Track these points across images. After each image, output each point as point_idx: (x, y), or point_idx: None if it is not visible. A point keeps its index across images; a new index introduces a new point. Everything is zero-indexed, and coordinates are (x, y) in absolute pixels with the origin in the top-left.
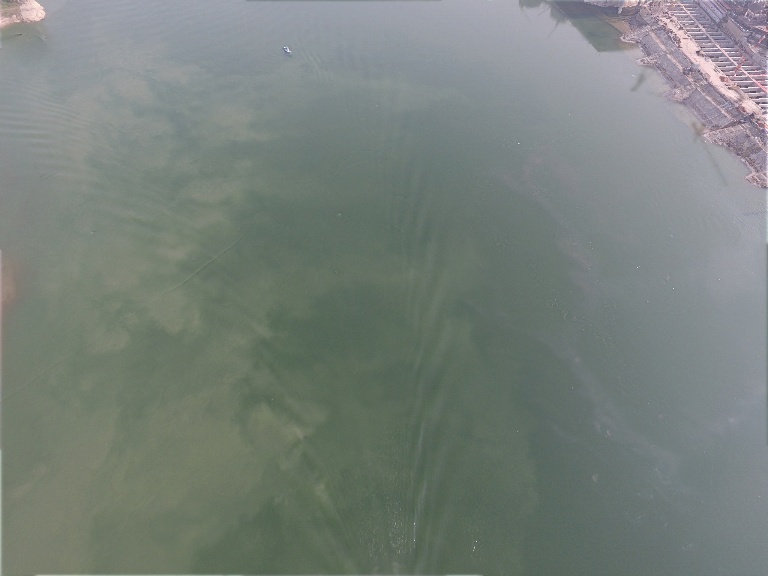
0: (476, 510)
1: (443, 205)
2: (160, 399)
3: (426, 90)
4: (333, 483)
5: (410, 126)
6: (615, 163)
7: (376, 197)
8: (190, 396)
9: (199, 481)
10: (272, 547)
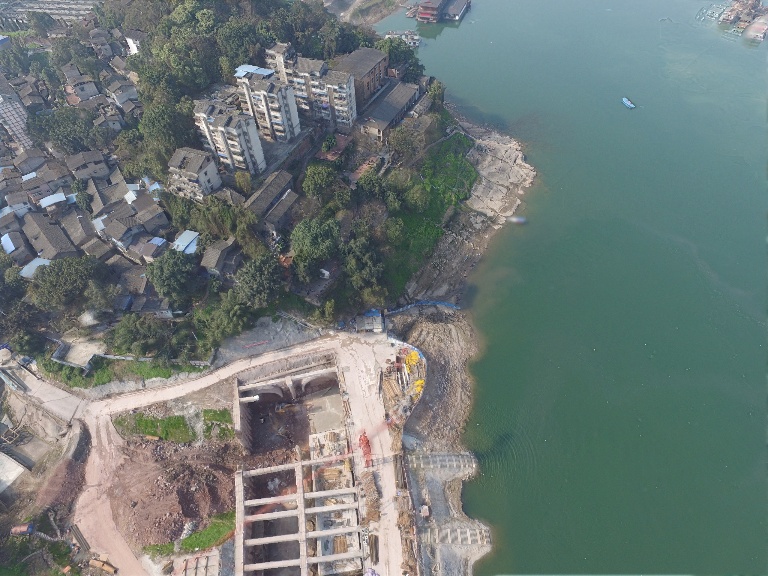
0: None
1: None
2: None
3: None
4: None
5: None
6: None
7: None
8: None
9: None
10: None
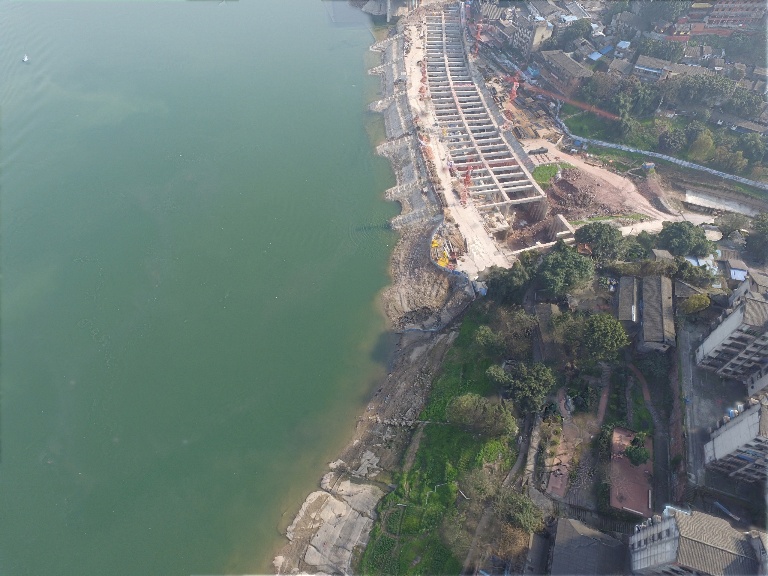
0: None
1: (52, 219)
2: None
3: (135, 100)
4: None
5: (92, 137)
6: (266, 176)
7: None
8: None
9: None
10: None
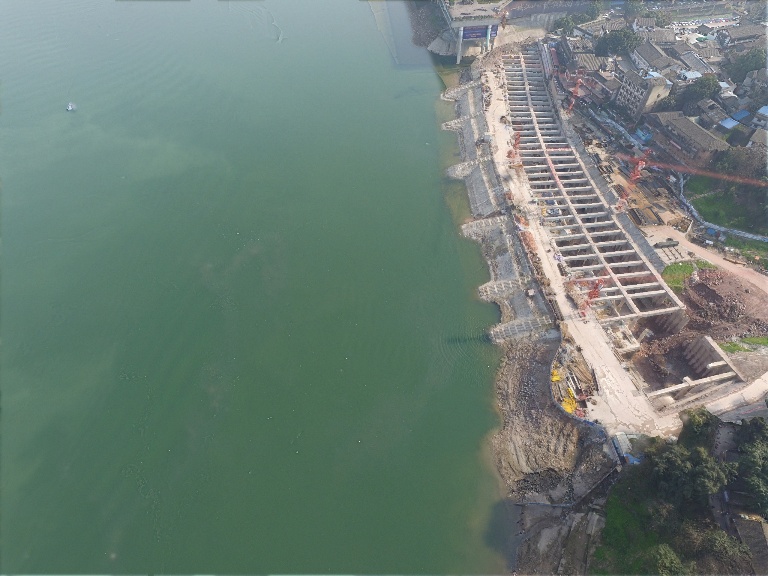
0: None
1: (94, 318)
2: None
3: (185, 159)
4: None
5: (139, 205)
6: (336, 262)
7: (23, 305)
8: None
9: None
10: None
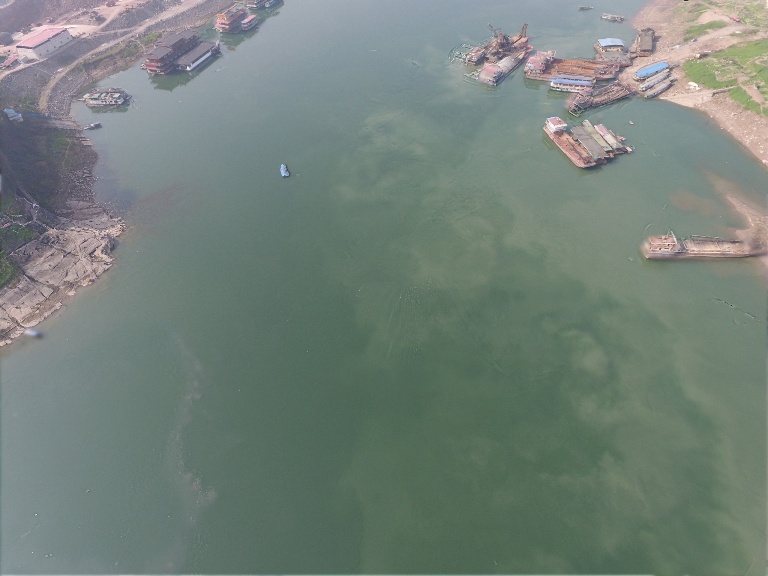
0: (356, 305)
1: None
2: (651, 403)
3: None
4: (462, 328)
5: None
6: None
7: None
8: (620, 404)
9: (567, 318)
10: (499, 293)
